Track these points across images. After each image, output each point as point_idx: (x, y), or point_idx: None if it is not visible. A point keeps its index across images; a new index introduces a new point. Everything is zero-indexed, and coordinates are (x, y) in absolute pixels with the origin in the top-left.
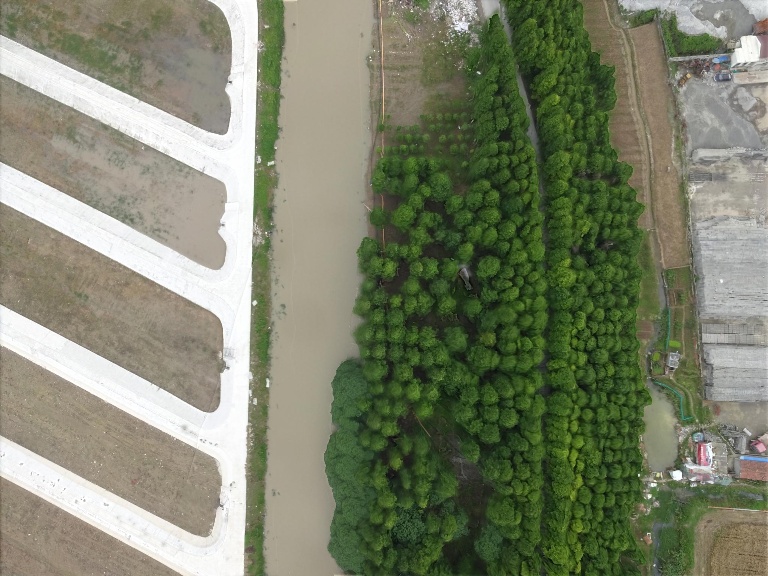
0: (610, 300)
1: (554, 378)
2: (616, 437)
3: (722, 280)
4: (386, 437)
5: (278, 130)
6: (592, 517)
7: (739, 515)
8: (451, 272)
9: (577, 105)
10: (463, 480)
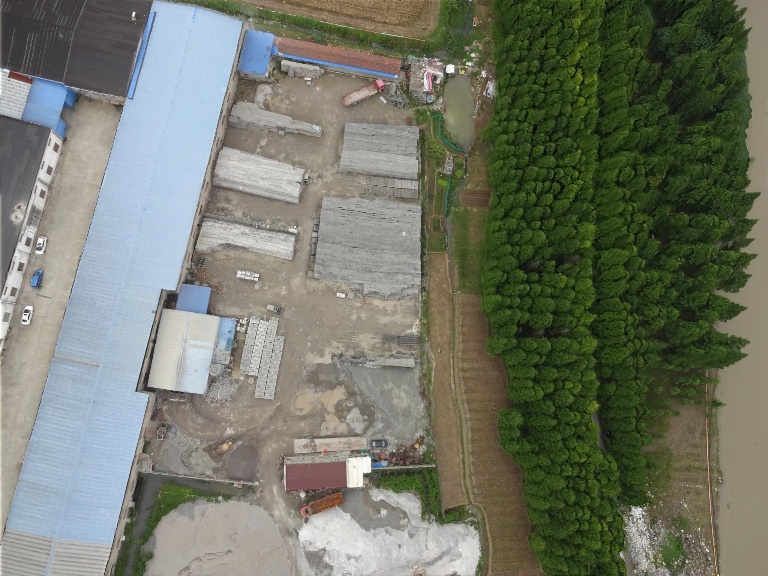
0: (543, 210)
1: None
2: (538, 92)
3: (404, 235)
4: None
5: None
6: (560, 30)
7: (398, 32)
8: None
9: None
10: None
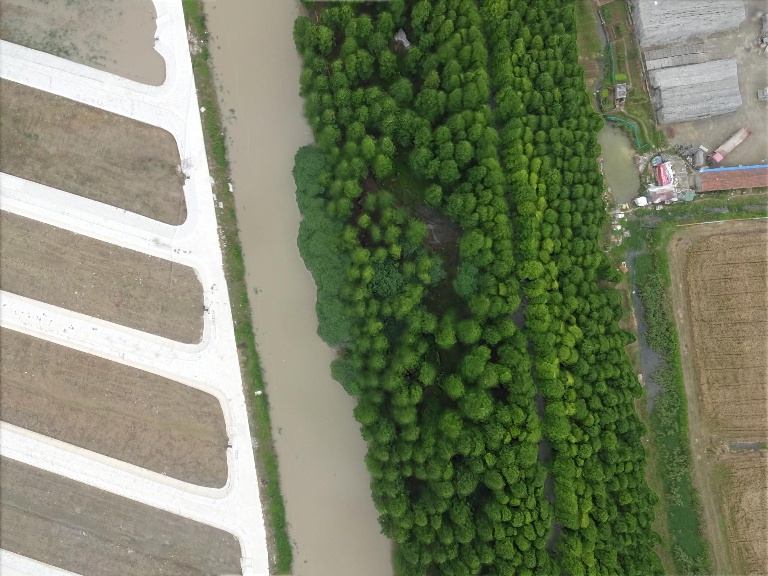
0: (545, 23)
1: (503, 108)
2: (572, 156)
3: (656, 2)
4: (350, 198)
5: None
6: (561, 236)
7: (707, 228)
8: (385, 24)
9: None
10: (437, 245)
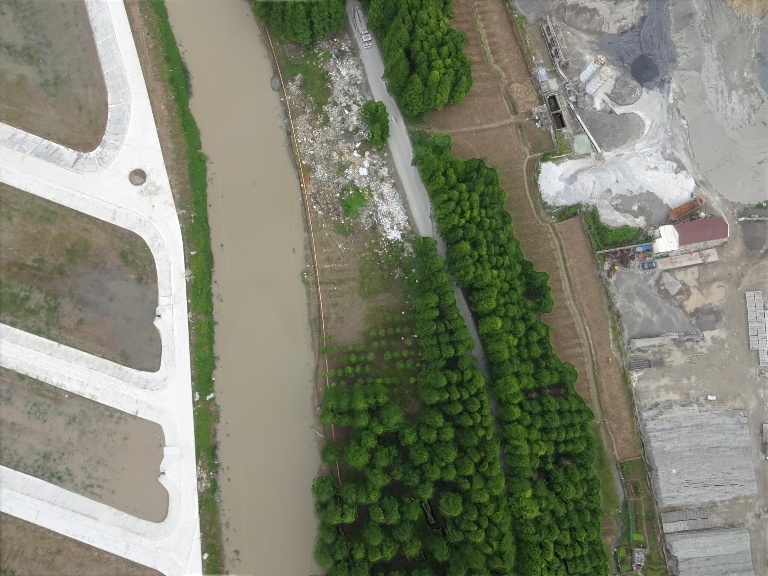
0: (574, 523)
1: None
2: None
3: (674, 470)
4: None
5: (215, 359)
6: None
7: None
8: (413, 515)
9: (519, 327)
10: None
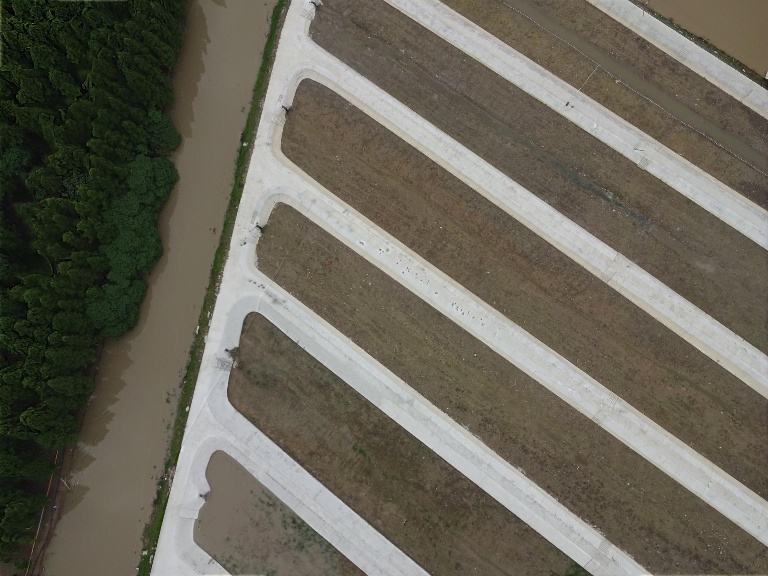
0: None
1: None
2: None
3: None
4: None
5: None
6: None
7: None
8: None
9: None
10: None
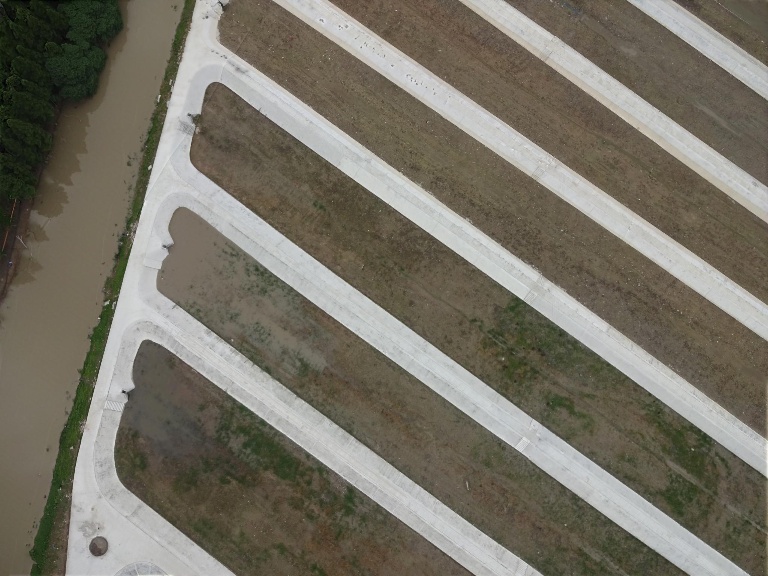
0: None
1: None
2: None
3: None
4: None
5: None
6: None
7: None
8: None
9: None
10: None
